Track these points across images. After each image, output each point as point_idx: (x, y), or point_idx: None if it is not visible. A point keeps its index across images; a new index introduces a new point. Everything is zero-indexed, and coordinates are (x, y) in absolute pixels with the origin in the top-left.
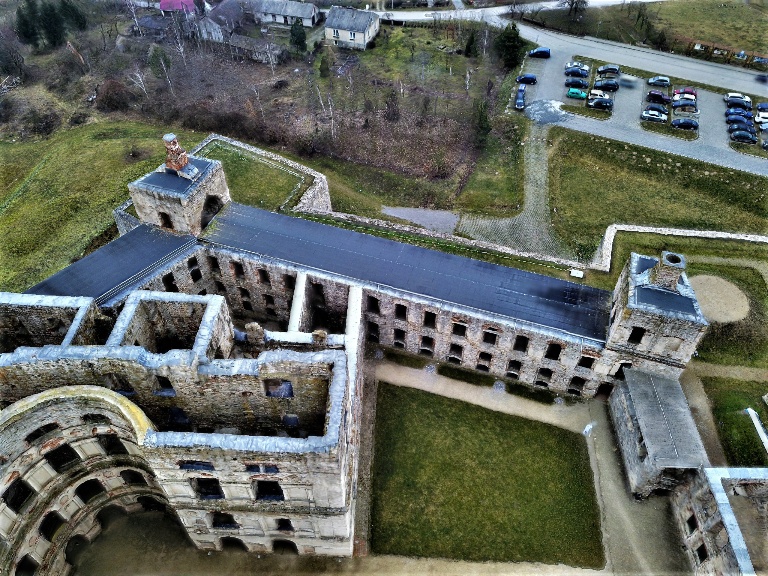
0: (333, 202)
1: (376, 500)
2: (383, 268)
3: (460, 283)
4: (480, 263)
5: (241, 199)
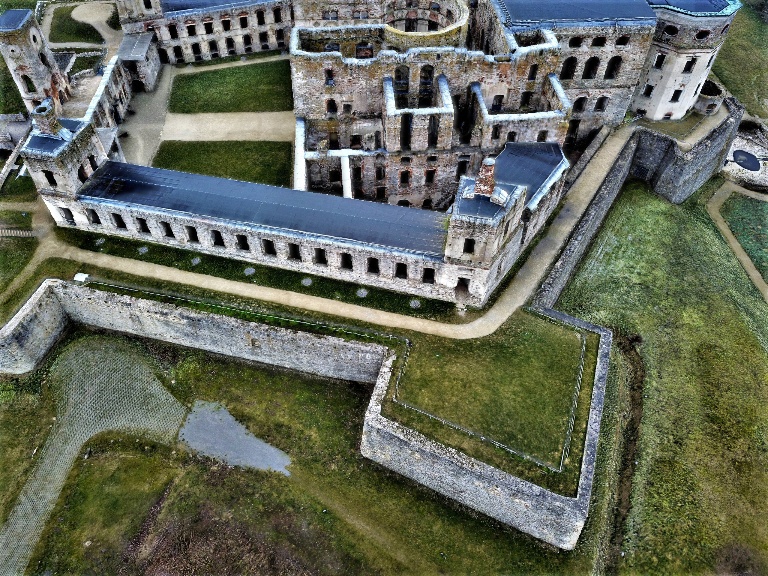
0: (363, 473)
1: (288, 160)
2: (275, 198)
3: (208, 190)
4: (185, 208)
5: (466, 358)
